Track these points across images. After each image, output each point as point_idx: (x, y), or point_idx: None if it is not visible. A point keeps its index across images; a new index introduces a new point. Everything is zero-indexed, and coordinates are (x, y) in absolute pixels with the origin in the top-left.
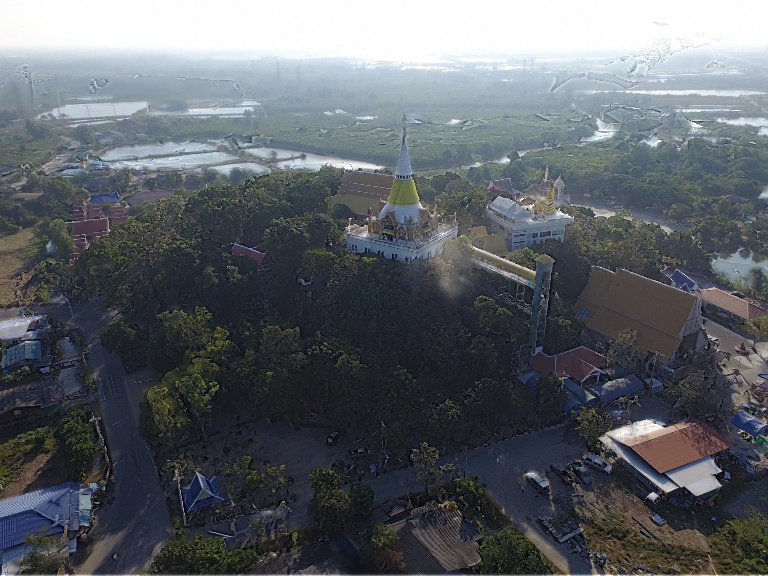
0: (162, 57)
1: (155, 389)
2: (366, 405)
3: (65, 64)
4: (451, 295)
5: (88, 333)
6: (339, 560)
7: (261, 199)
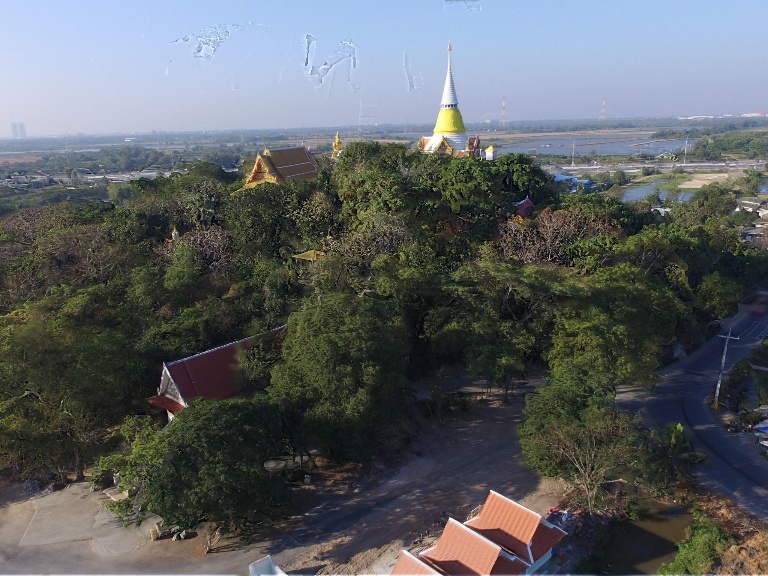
0: None
1: None
2: None
3: None
4: None
5: (707, 389)
6: None
7: None
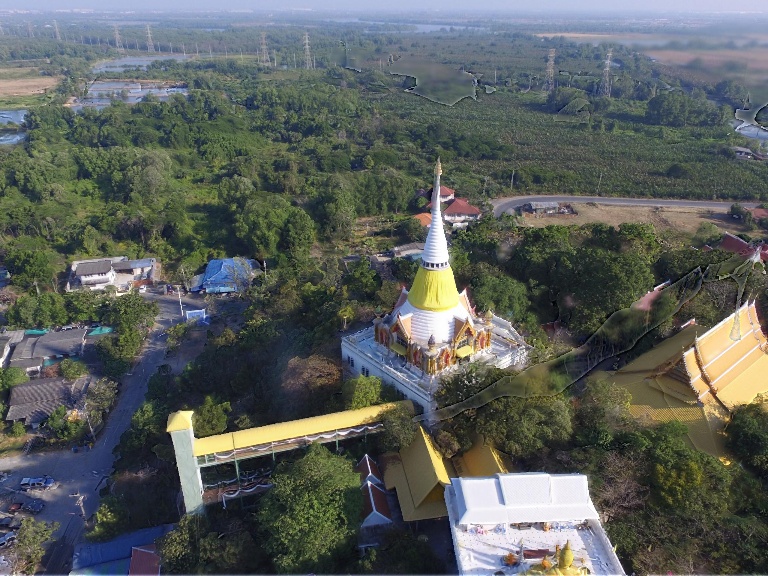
0: (716, 47)
1: (236, 257)
2: (195, 366)
3: (615, 45)
4: (286, 404)
5: None
6: (88, 363)
7: None
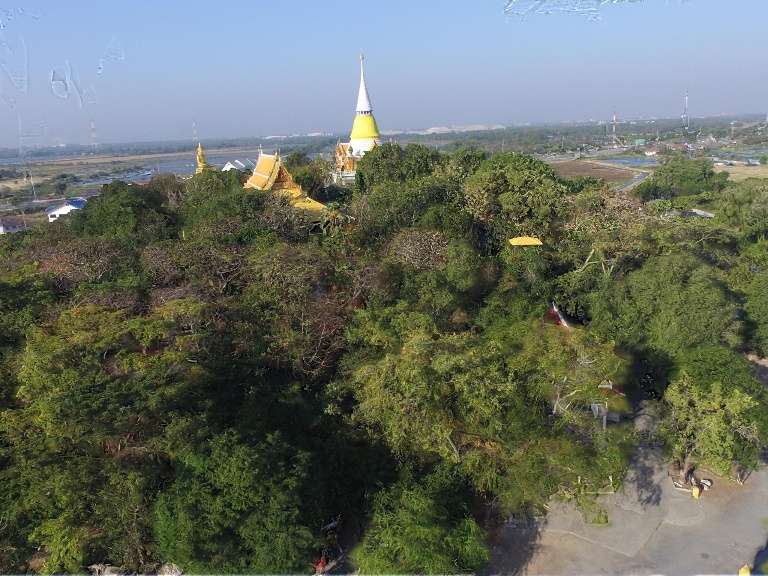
0: None
1: None
2: None
3: None
4: None
5: None
6: None
7: (469, 155)
